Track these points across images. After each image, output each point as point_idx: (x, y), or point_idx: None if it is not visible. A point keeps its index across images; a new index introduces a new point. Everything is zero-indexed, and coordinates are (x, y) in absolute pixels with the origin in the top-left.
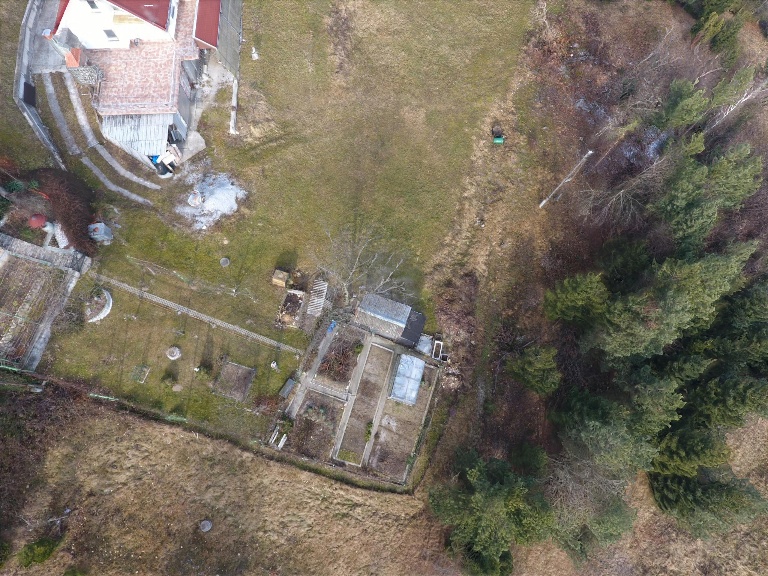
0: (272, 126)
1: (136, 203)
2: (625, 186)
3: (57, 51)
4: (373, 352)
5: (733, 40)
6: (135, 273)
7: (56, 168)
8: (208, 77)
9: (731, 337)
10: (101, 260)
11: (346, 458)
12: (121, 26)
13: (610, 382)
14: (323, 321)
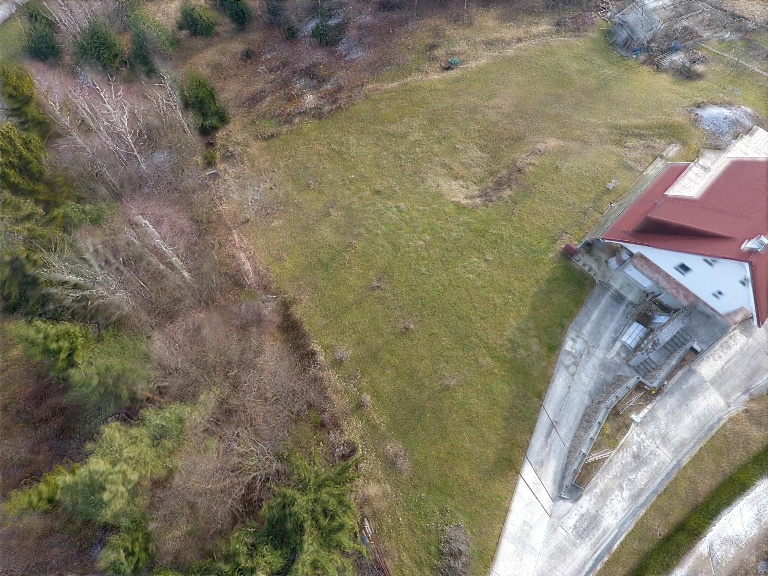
0: None
1: None
2: None
3: None
4: None
5: None
6: None
7: None
8: None
9: None
10: None
11: (699, 6)
12: None
13: None
14: None
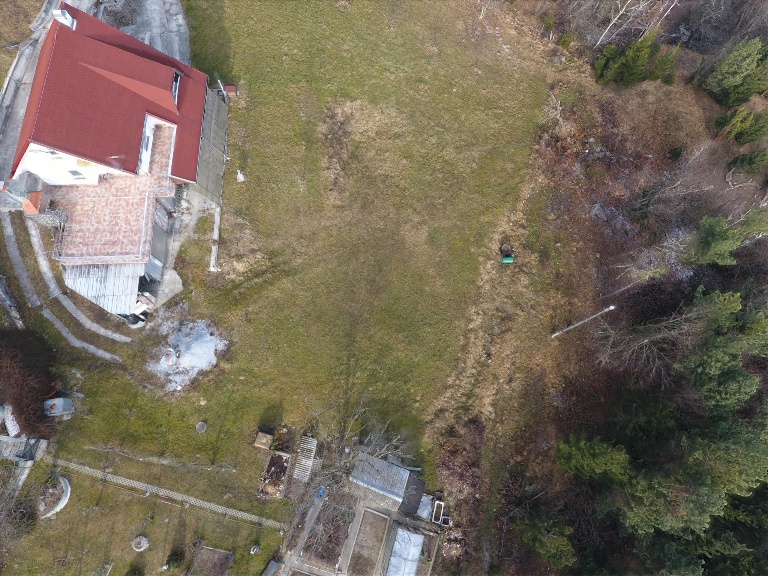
0: (258, 257)
1: (103, 361)
2: (648, 331)
3: (13, 199)
4: (366, 519)
5: (761, 133)
6: (98, 451)
7: (12, 328)
8: (188, 203)
9: (763, 494)
10: (59, 441)
11: None
12: (87, 167)
13: (628, 541)
14: (311, 484)
